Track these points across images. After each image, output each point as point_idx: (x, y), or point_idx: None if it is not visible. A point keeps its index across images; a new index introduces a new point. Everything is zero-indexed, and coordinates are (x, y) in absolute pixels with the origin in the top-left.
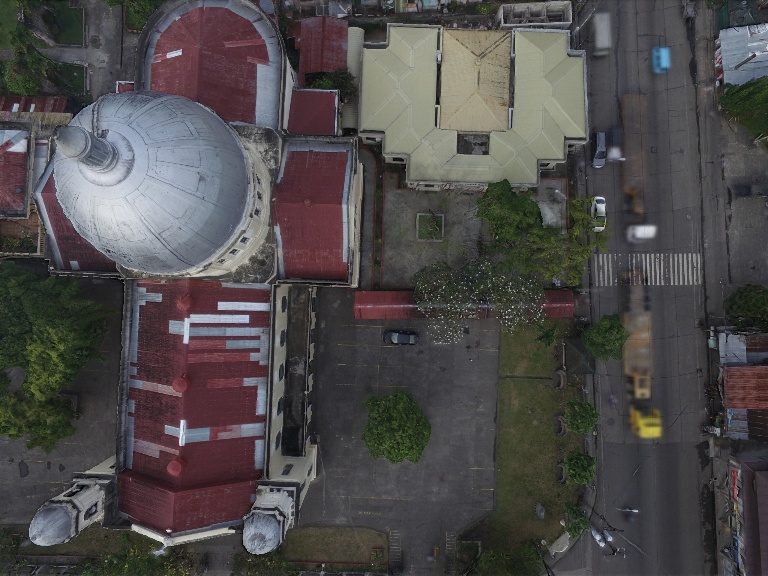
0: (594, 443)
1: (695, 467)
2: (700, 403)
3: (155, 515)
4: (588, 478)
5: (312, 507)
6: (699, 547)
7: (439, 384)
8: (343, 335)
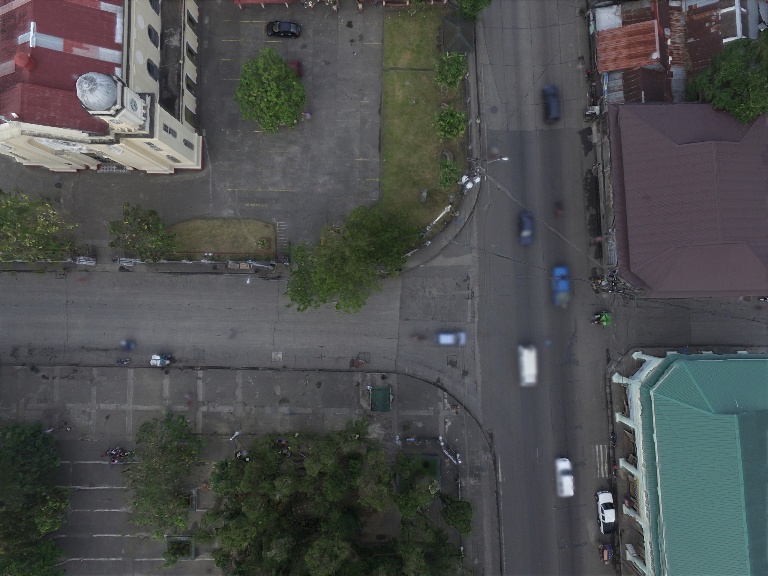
0: (478, 131)
1: (578, 152)
2: (582, 90)
3: (7, 114)
4: (459, 131)
5: (199, 200)
6: (583, 231)
7: (323, 77)
8: (227, 30)
